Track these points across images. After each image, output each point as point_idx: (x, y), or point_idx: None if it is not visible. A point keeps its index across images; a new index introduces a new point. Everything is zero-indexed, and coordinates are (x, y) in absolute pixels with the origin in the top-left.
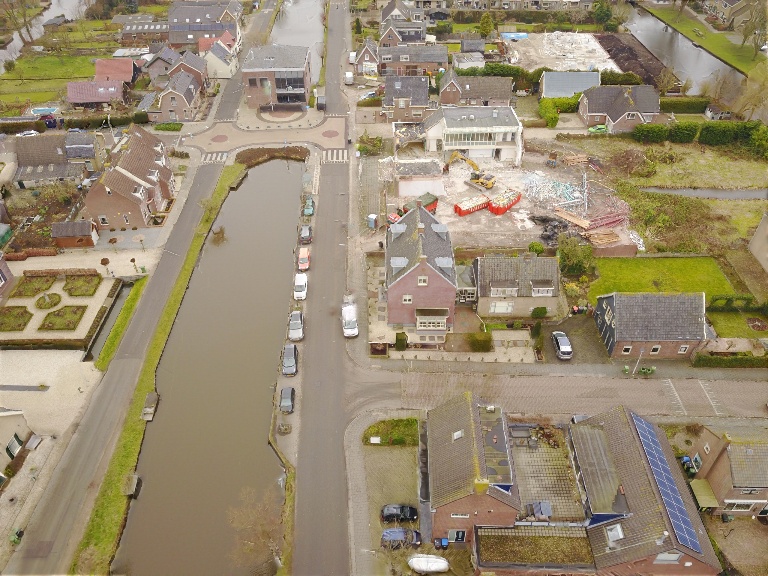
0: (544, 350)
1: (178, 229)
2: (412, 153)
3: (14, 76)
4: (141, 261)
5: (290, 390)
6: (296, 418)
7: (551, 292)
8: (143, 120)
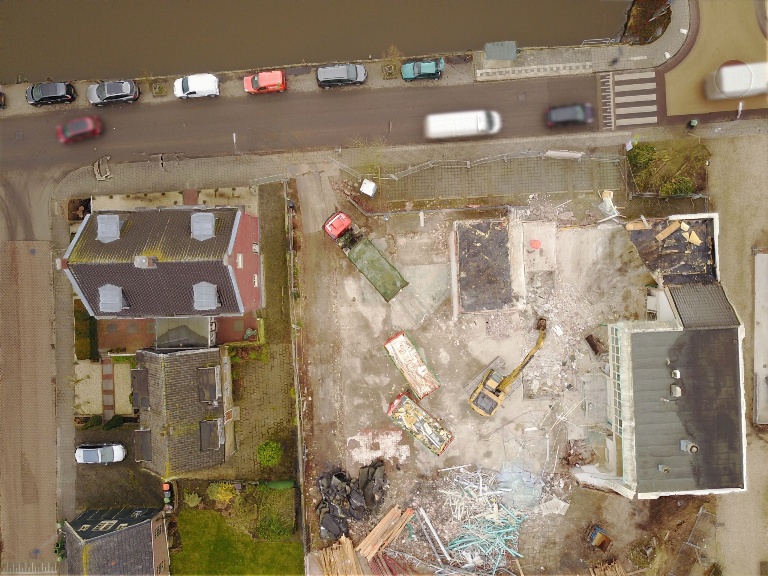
0: (97, 428)
1: None
2: (639, 260)
3: None
4: None
5: None
6: None
7: None
8: None
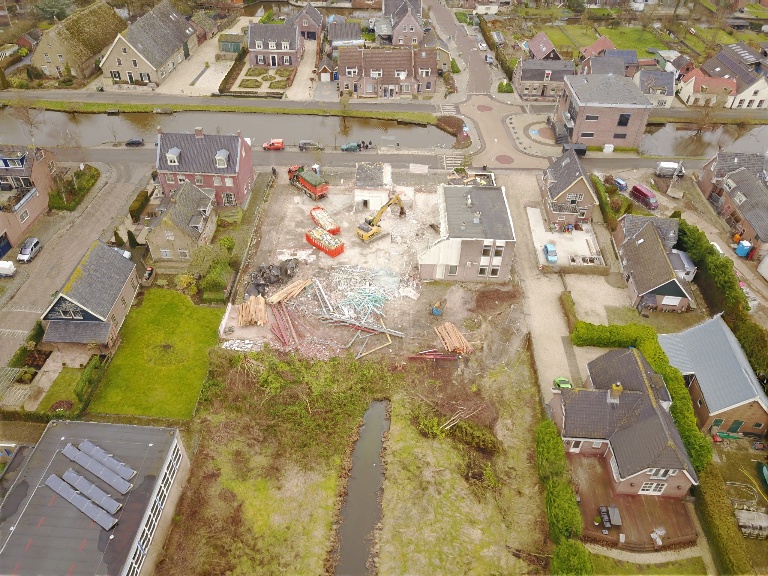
0: None
1: (335, 103)
2: None
3: (601, 30)
4: (299, 96)
5: (137, 139)
6: (122, 148)
7: (148, 232)
8: (509, 74)
